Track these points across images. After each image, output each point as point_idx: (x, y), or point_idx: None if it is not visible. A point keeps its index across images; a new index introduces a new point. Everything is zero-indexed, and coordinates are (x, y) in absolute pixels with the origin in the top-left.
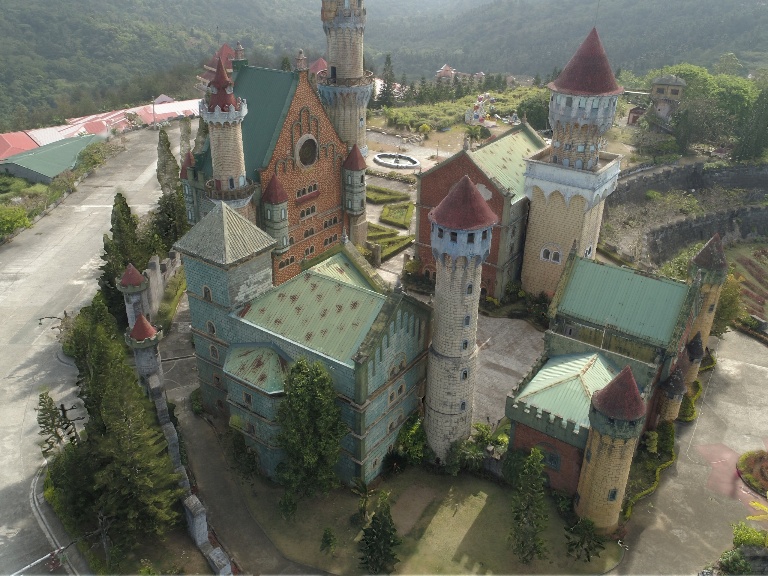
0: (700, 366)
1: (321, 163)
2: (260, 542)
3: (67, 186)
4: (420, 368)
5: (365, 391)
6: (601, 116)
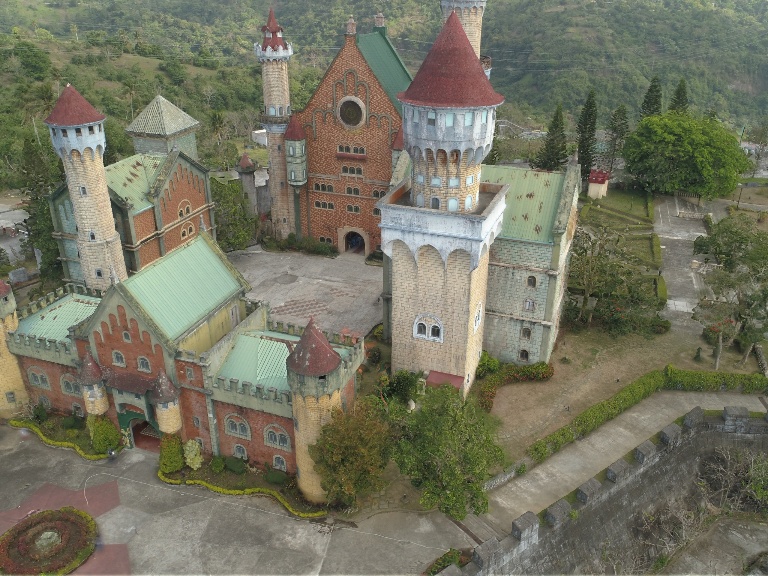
0: (293, 500)
1: (373, 131)
2: (44, 288)
3: (510, 151)
4: (126, 256)
5: (57, 224)
6: (411, 132)
